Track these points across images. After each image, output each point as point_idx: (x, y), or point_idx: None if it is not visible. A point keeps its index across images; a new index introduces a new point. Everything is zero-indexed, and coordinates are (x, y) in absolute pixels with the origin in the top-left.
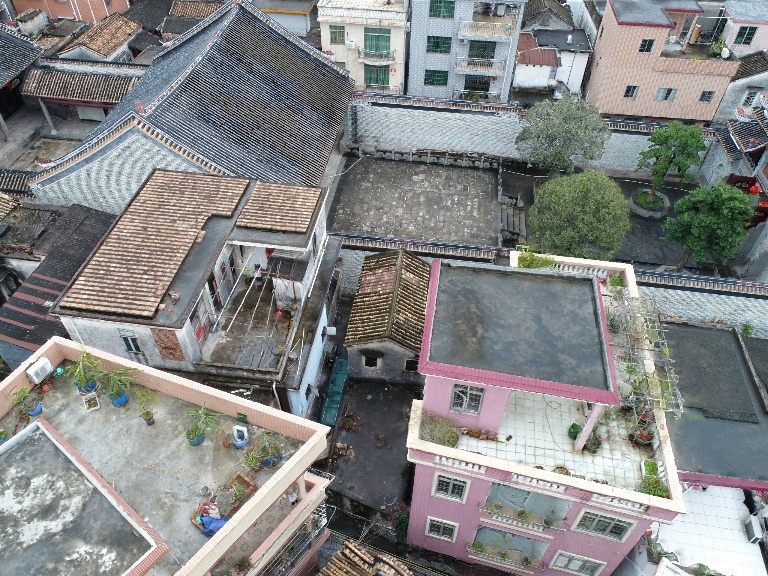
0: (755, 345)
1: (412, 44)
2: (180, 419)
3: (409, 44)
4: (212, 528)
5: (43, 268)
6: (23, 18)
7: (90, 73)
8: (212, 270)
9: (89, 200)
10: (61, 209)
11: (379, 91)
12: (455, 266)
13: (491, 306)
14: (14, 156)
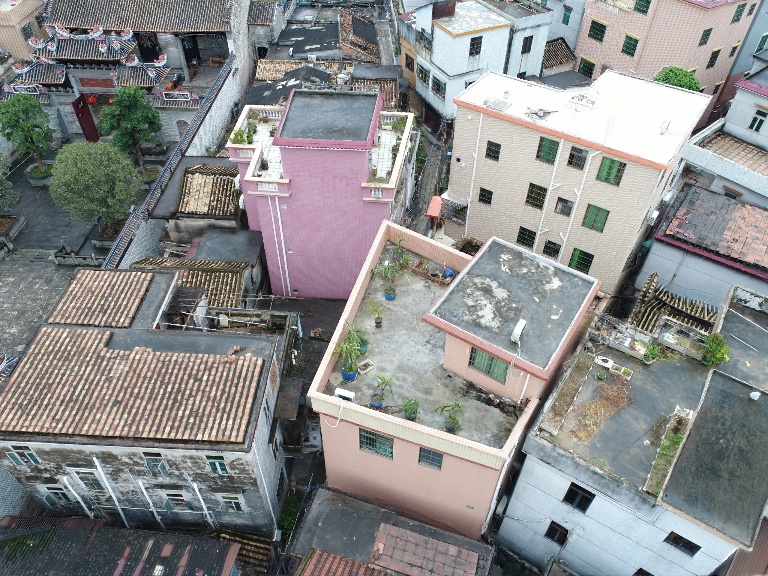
0: None
1: None
2: None
3: None
4: (452, 271)
5: None
6: None
7: None
8: None
9: None
10: None
11: None
12: None
13: (317, 125)
14: None
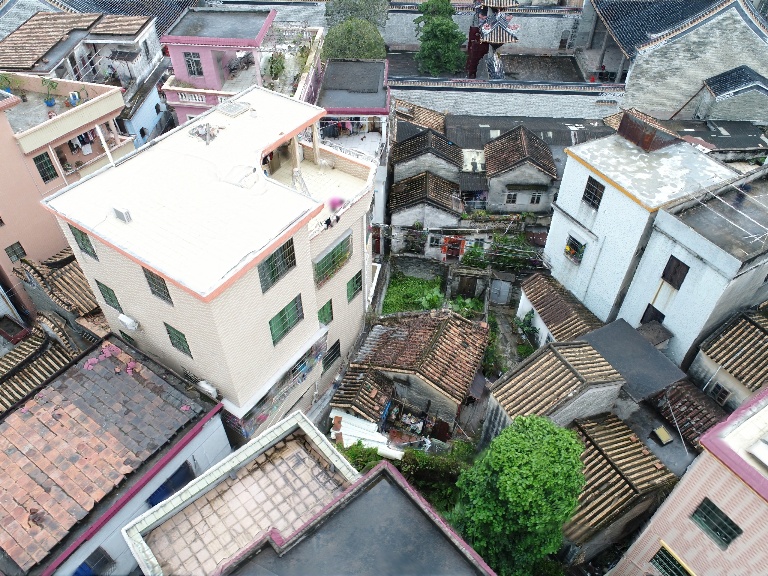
0: (459, 117)
1: None
2: (42, 99)
3: None
4: None
5: None
6: None
7: None
8: (73, 55)
9: None
10: None
11: None
12: (197, 11)
13: (210, 22)
14: None
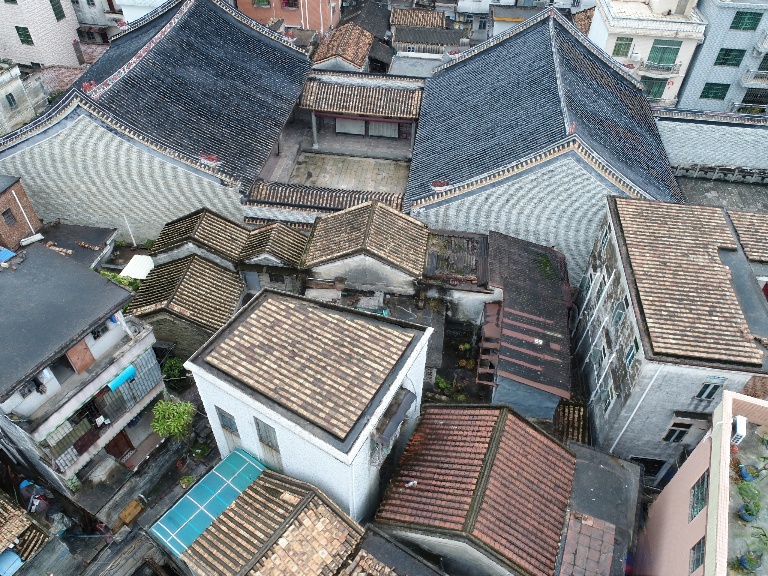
0: None
1: (701, 56)
2: None
3: (694, 56)
4: None
5: (509, 302)
6: (272, 27)
7: (358, 85)
8: None
9: (471, 224)
10: (472, 236)
11: (653, 104)
12: None
13: None
14: (289, 172)
